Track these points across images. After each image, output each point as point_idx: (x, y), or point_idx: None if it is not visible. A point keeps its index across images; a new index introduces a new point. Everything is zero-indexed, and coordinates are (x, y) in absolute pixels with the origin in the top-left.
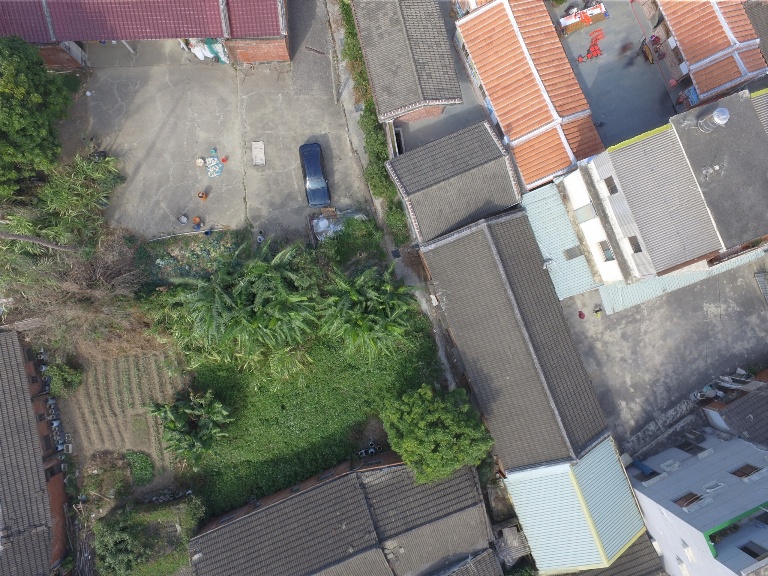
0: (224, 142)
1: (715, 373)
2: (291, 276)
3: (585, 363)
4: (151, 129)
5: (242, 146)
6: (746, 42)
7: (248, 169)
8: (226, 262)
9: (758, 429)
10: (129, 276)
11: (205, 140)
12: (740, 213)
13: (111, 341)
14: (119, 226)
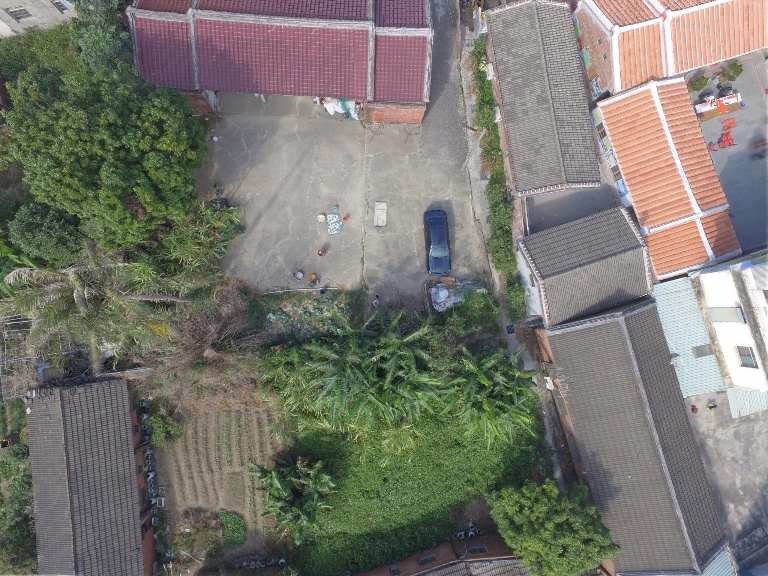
0: (346, 199)
1: None
2: (424, 356)
3: None
4: (275, 180)
5: (364, 205)
6: None
7: (369, 229)
8: (354, 332)
9: None
10: (254, 338)
11: (328, 196)
12: None
13: (216, 395)
14: (234, 276)
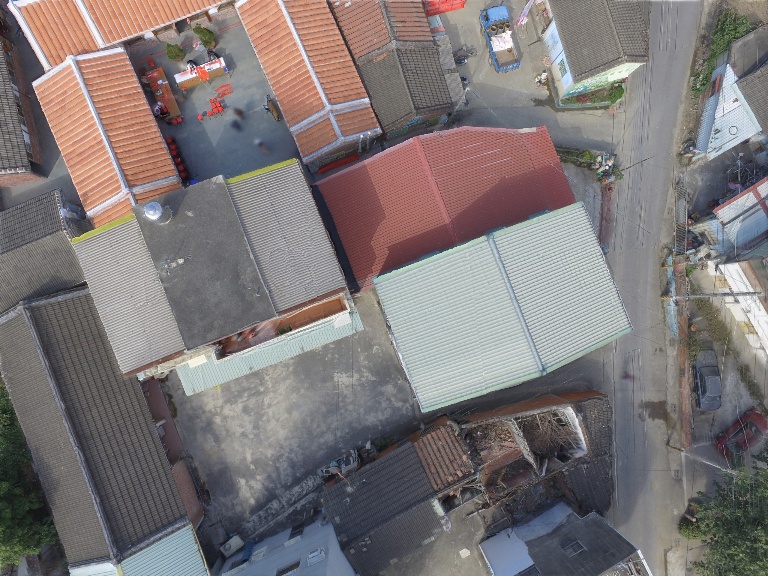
0: None
1: (345, 447)
2: None
3: (202, 439)
4: None
5: None
6: (346, 103)
7: None
8: None
9: (351, 514)
10: None
11: None
12: (205, 310)
13: None
14: None
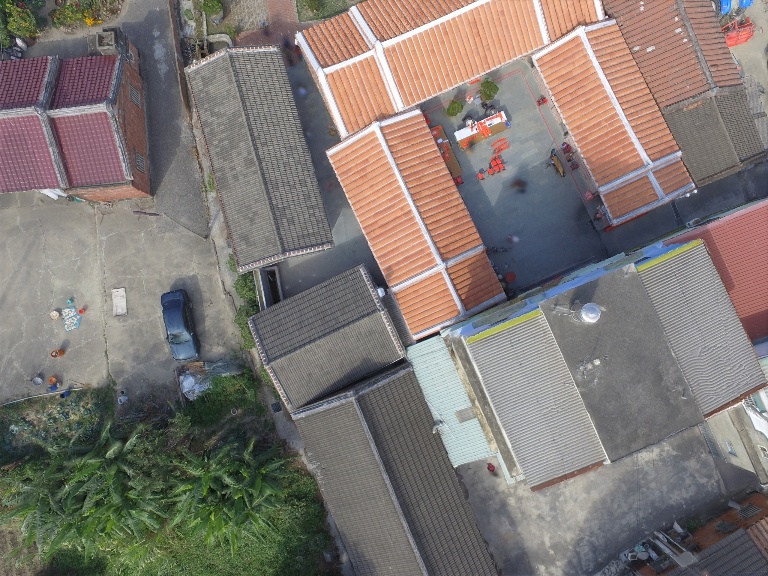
0: (82, 290)
1: (649, 528)
2: (127, 473)
3: (496, 522)
4: (1, 280)
5: (102, 293)
6: (663, 158)
7: (109, 320)
8: (61, 452)
9: None
10: None
11: (61, 289)
12: (627, 417)
13: None
14: None
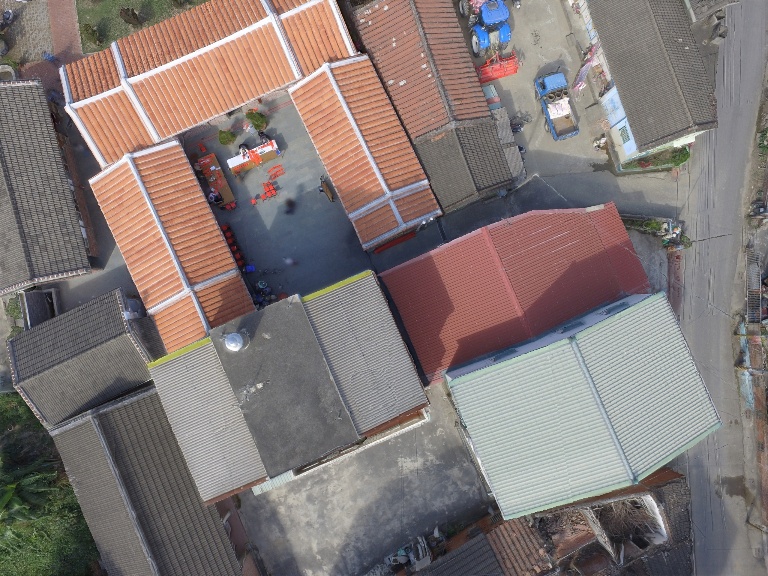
0: None
1: (412, 534)
2: None
3: (267, 530)
4: None
5: None
6: (405, 187)
7: None
8: None
9: None
10: None
11: None
12: (286, 436)
13: None
14: None
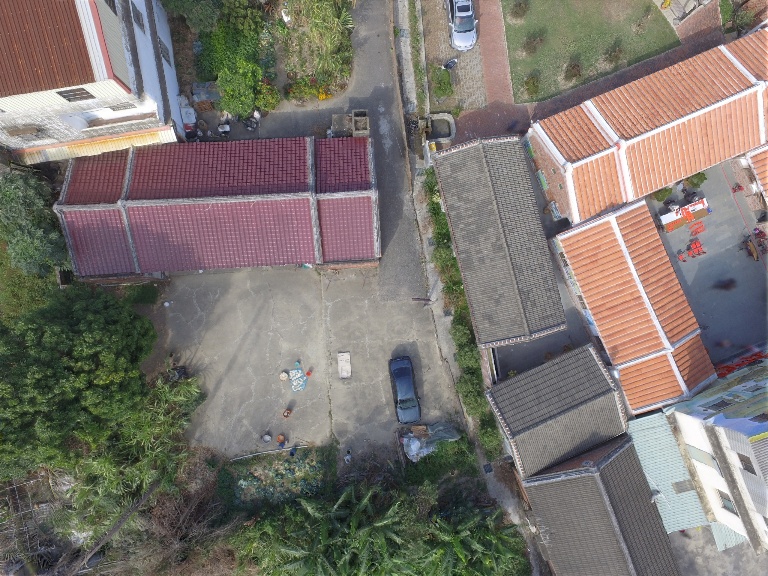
0: (308, 352)
1: None
2: (396, 540)
3: None
4: (232, 341)
5: (327, 356)
6: None
7: (334, 382)
8: (324, 516)
9: None
10: (223, 532)
11: (288, 351)
12: None
13: None
14: (200, 445)
